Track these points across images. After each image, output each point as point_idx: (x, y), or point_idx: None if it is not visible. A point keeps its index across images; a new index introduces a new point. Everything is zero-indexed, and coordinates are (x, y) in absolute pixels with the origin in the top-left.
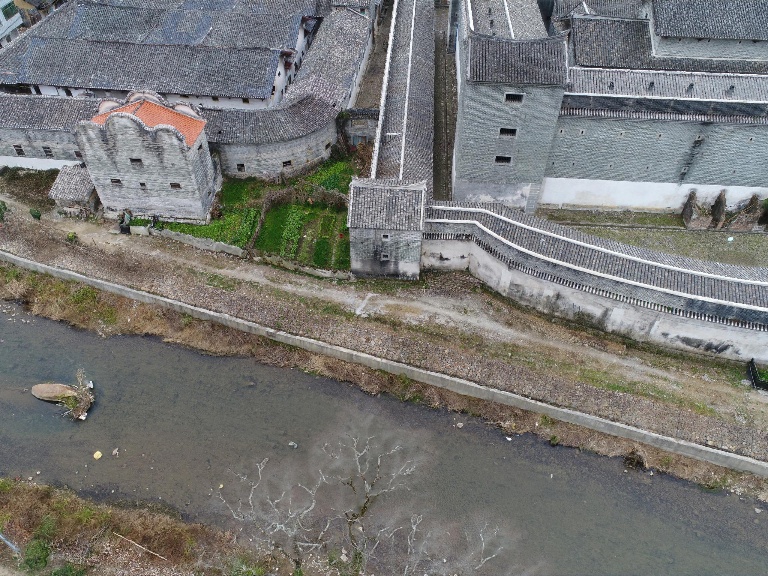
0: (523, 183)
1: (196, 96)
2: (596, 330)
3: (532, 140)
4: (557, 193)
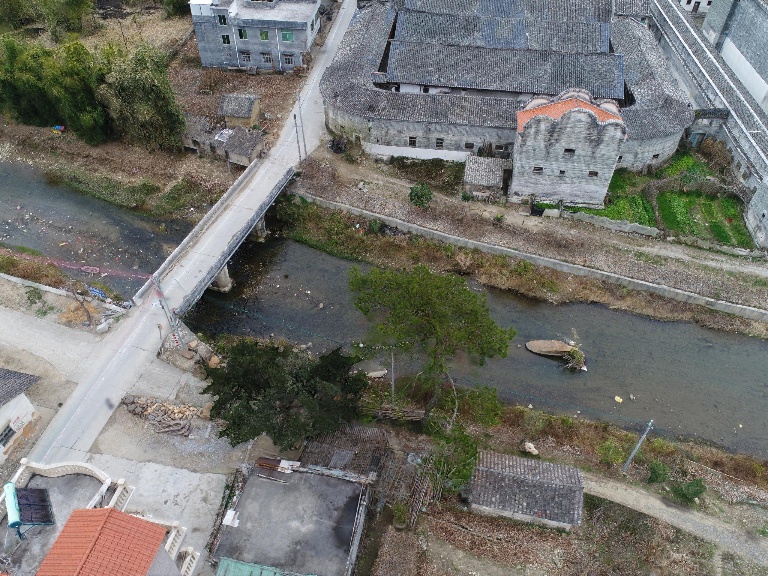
0: None
1: (551, 95)
2: None
3: None
4: None
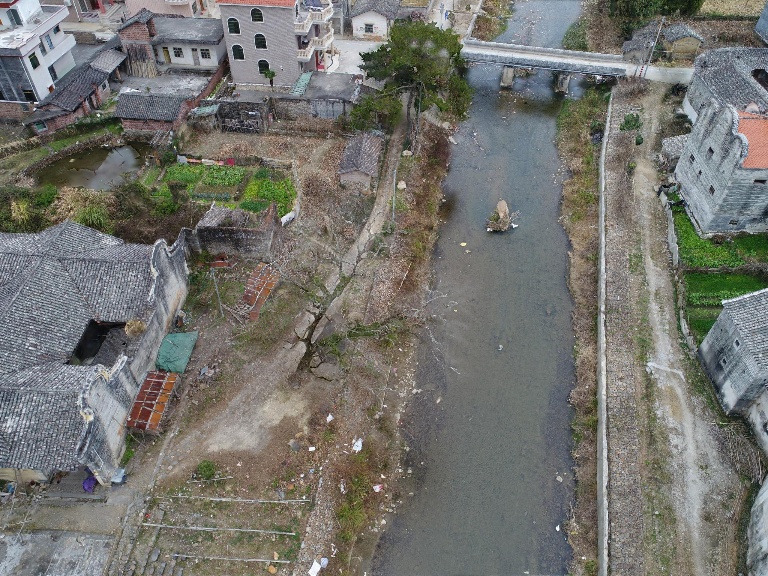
0: None
1: None
2: None
3: None
4: None
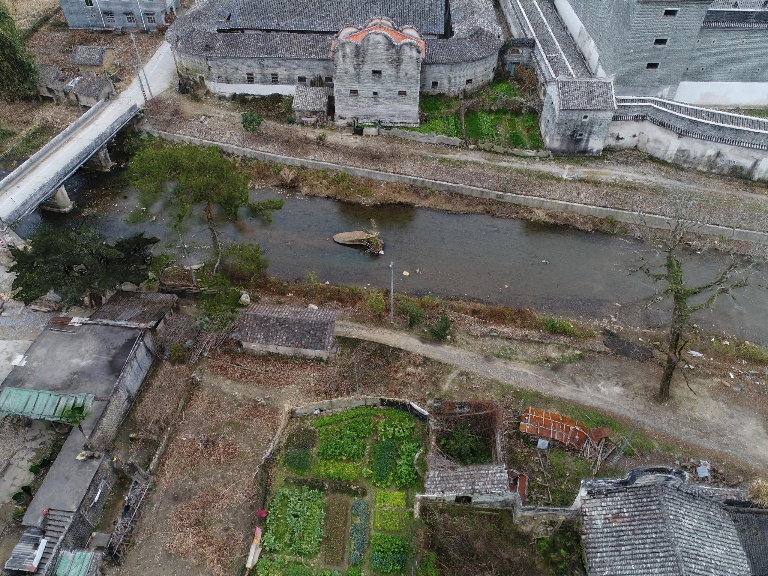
0: (664, 86)
1: None
2: (745, 180)
3: (678, 48)
4: (686, 95)
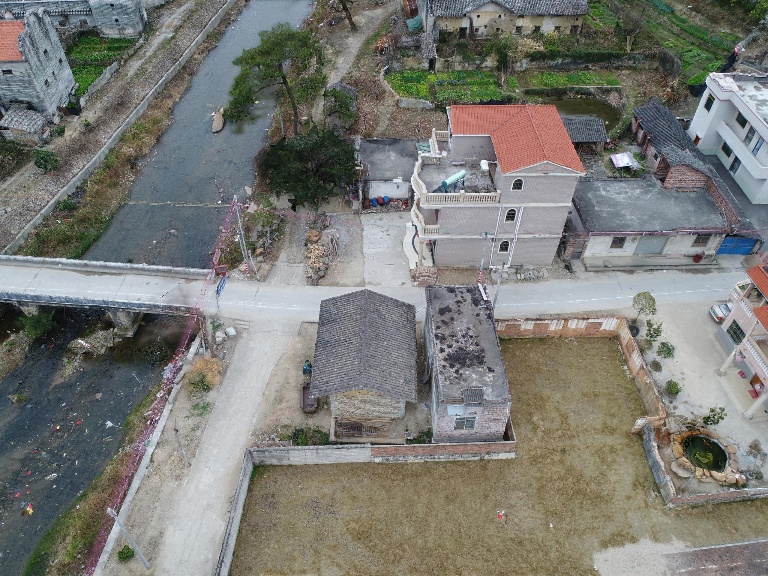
0: None
1: None
2: None
3: None
4: None
